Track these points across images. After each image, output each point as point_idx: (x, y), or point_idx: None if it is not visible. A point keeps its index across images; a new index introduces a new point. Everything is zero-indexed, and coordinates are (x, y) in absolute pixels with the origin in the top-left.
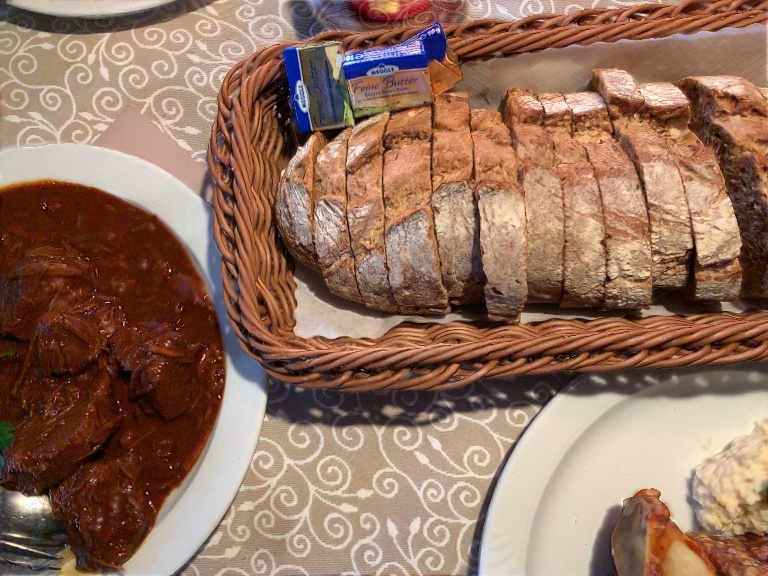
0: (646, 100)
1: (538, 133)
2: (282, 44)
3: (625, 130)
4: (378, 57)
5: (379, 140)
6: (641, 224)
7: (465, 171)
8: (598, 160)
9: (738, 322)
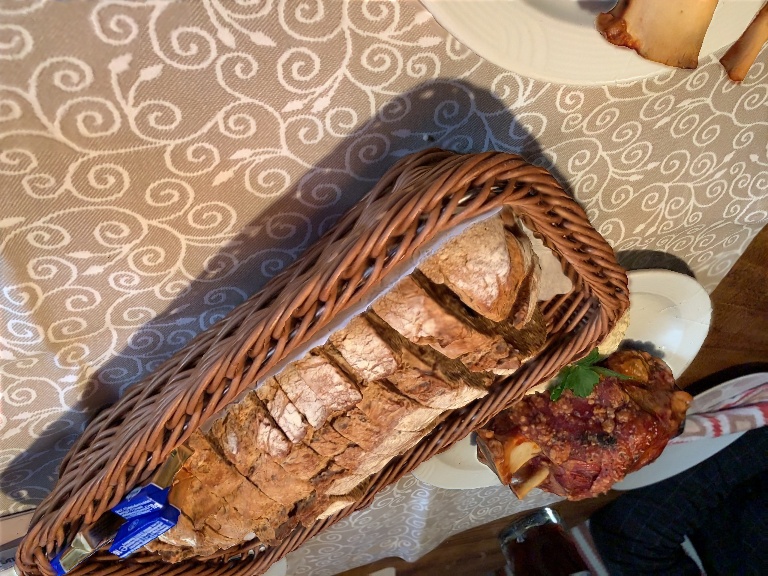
0: (357, 371)
1: (303, 462)
2: (26, 549)
3: (360, 405)
4: (140, 544)
5: (196, 531)
6: (416, 437)
7: (277, 505)
8: (360, 441)
9: (503, 396)
